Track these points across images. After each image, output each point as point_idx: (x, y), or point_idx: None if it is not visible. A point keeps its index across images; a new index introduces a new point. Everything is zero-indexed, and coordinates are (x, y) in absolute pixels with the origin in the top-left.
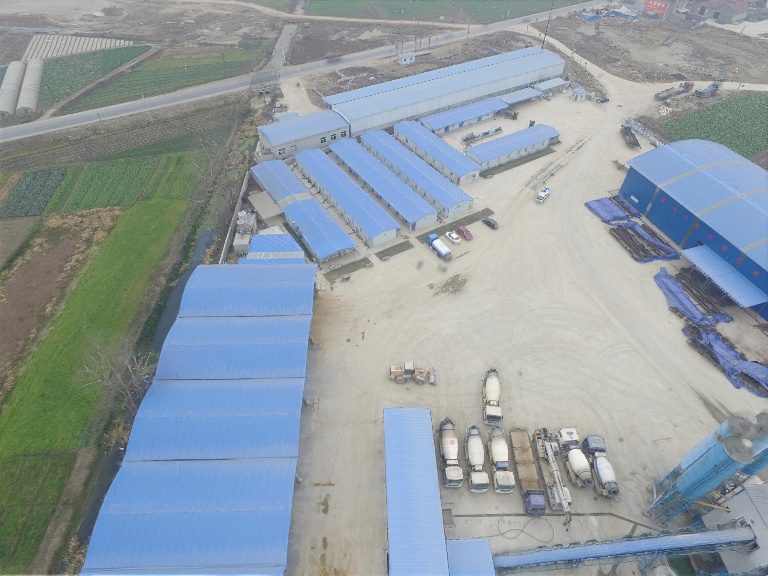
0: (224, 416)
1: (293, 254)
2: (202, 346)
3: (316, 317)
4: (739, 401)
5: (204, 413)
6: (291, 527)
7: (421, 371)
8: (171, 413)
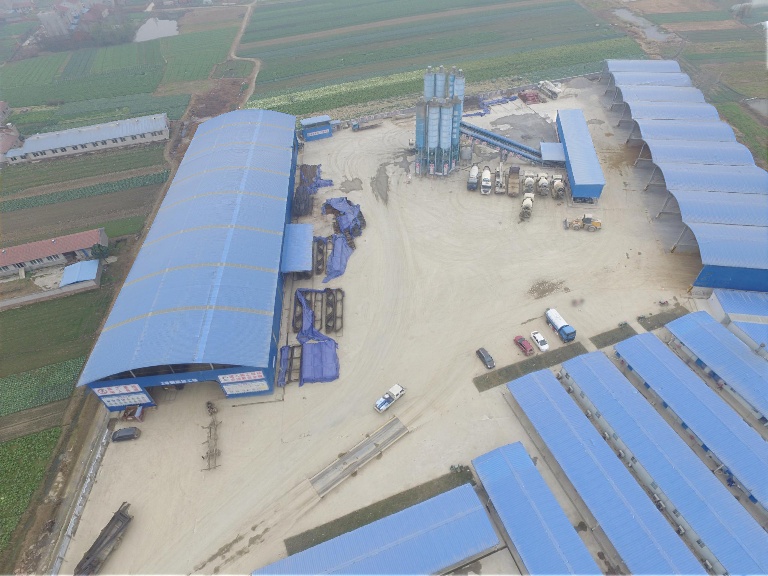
0: (710, 171)
1: (744, 318)
2: (761, 202)
3: (679, 273)
4: (365, 200)
5: (725, 173)
6: (642, 179)
7: (577, 220)
8: (747, 174)
